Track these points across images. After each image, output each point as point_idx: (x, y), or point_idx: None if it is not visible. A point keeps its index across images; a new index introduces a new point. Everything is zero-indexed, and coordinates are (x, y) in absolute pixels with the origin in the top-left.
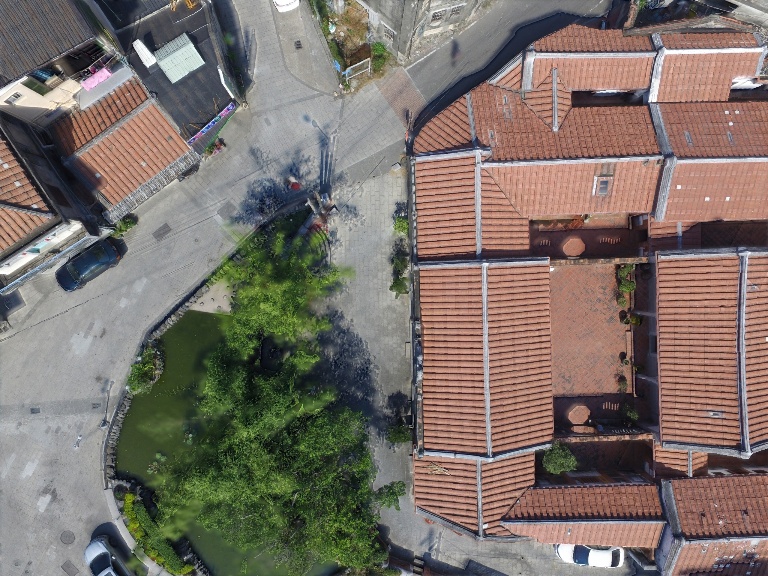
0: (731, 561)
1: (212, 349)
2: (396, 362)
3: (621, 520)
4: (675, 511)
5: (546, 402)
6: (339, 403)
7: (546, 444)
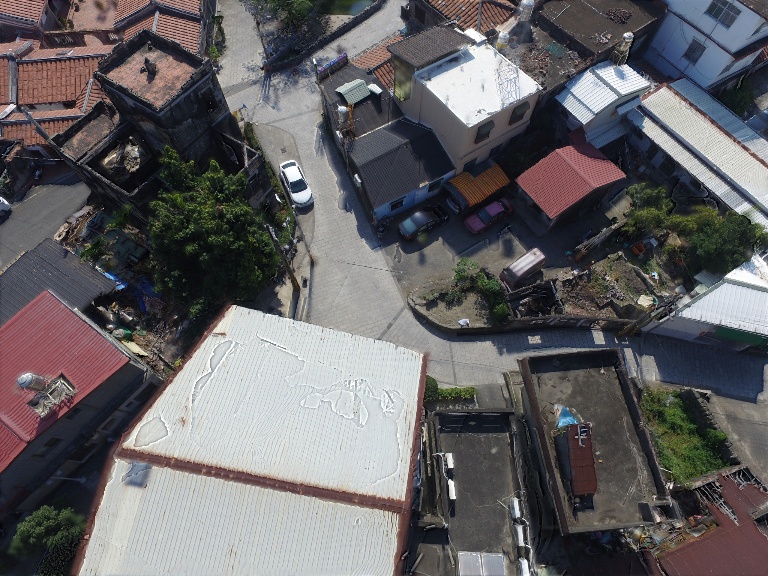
0: None
1: (343, 2)
2: (228, 4)
3: None
4: None
5: None
6: None
7: None
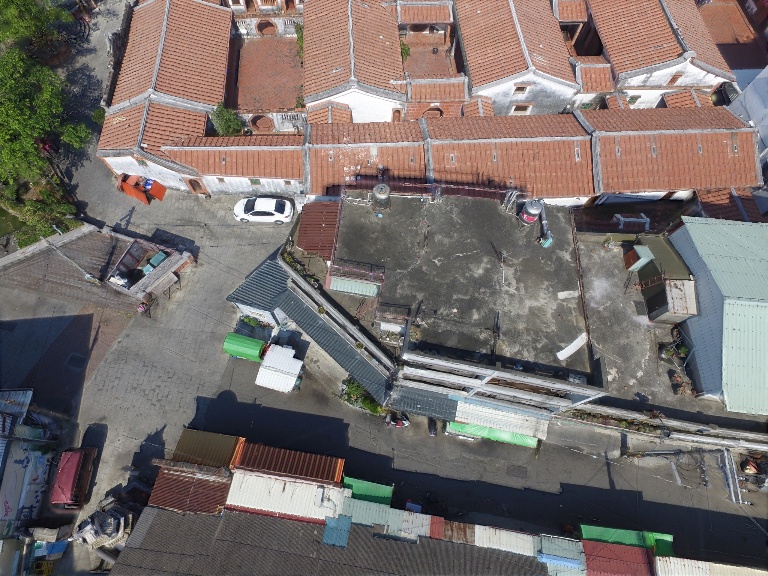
0: (360, 174)
1: None
2: None
3: (265, 146)
4: (308, 134)
5: (218, 83)
6: (69, 117)
7: (213, 105)
